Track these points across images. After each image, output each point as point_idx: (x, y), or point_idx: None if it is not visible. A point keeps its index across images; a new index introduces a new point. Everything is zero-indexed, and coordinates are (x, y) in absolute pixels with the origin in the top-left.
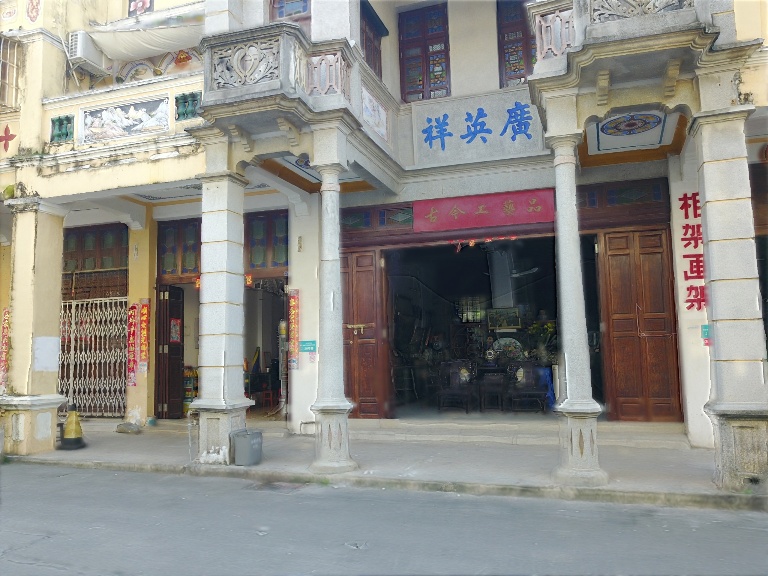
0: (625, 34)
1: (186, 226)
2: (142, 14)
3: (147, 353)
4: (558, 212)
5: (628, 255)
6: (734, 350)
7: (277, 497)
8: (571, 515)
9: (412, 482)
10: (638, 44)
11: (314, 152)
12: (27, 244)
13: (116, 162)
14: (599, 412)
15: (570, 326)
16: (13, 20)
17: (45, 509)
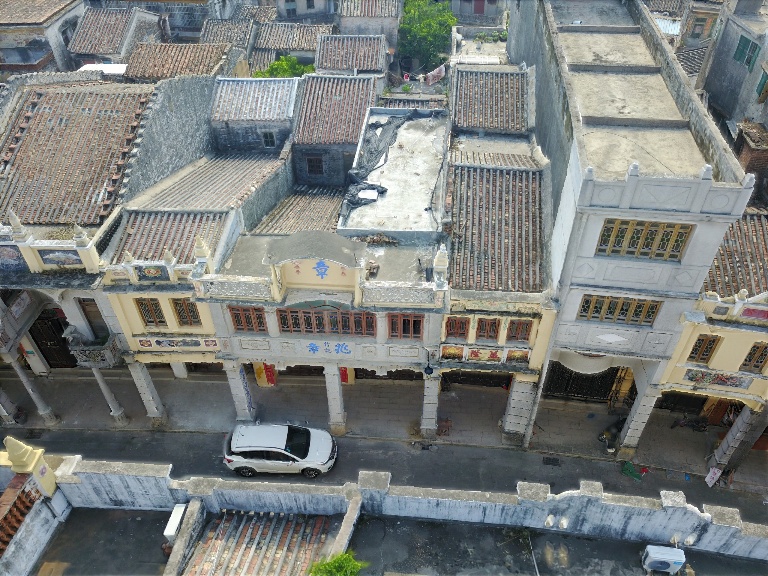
0: None
1: None
2: None
3: None
4: None
5: None
6: None
7: (36, 443)
8: (114, 442)
9: None
10: None
11: (3, 358)
12: None
13: None
14: None
15: None
16: None
17: None
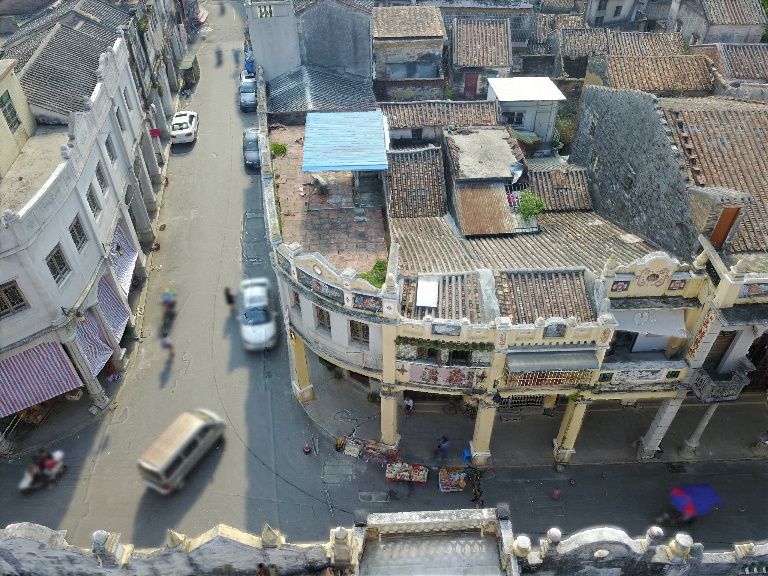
0: None
1: None
2: None
3: None
4: None
5: None
6: None
7: None
8: (766, 472)
9: None
10: None
11: None
12: (581, 412)
13: (631, 388)
14: None
15: None
16: (584, 335)
17: (648, 508)
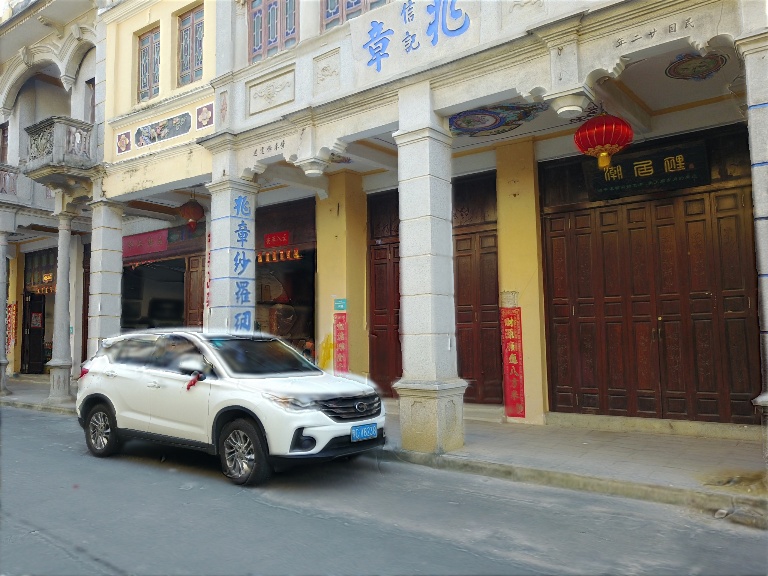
0: (31, 168)
1: (35, 256)
2: None
3: (15, 334)
4: None
5: (197, 271)
6: (92, 332)
7: None
8: None
9: (3, 401)
10: (39, 173)
11: None
12: None
13: None
14: (61, 366)
15: (55, 319)
16: None
17: None
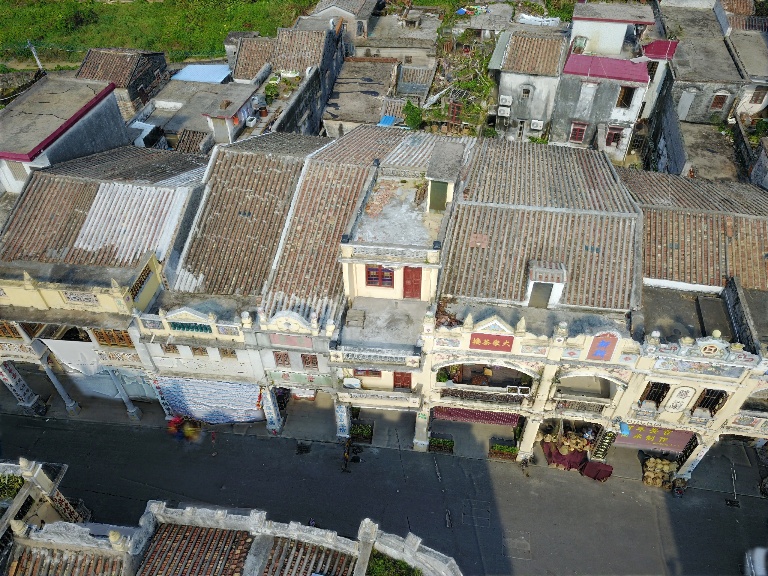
0: None
1: None
2: (108, 536)
3: None
4: None
5: None
6: None
7: None
8: None
9: None
10: None
11: None
12: None
13: None
14: None
15: None
16: None
17: None
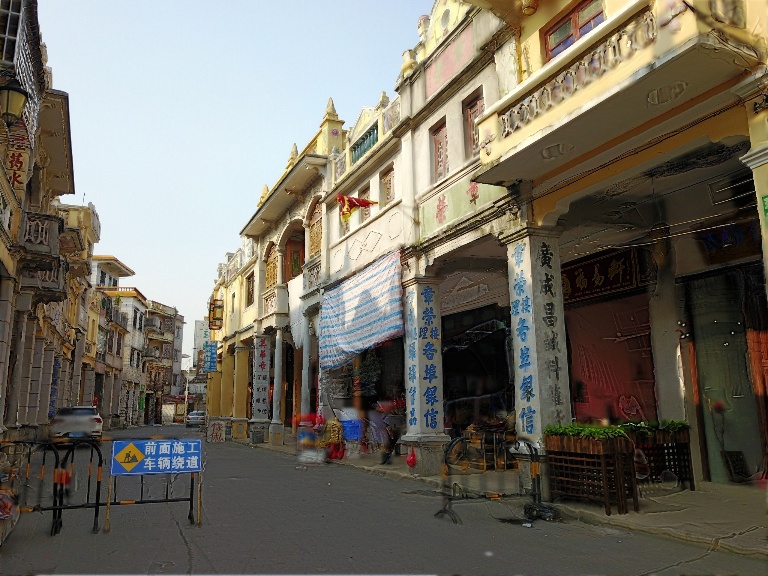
0: None
1: None
2: None
3: None
4: (22, 342)
5: None
6: None
7: None
8: None
9: None
10: None
11: None
12: None
13: None
14: None
15: None
16: None
17: None
